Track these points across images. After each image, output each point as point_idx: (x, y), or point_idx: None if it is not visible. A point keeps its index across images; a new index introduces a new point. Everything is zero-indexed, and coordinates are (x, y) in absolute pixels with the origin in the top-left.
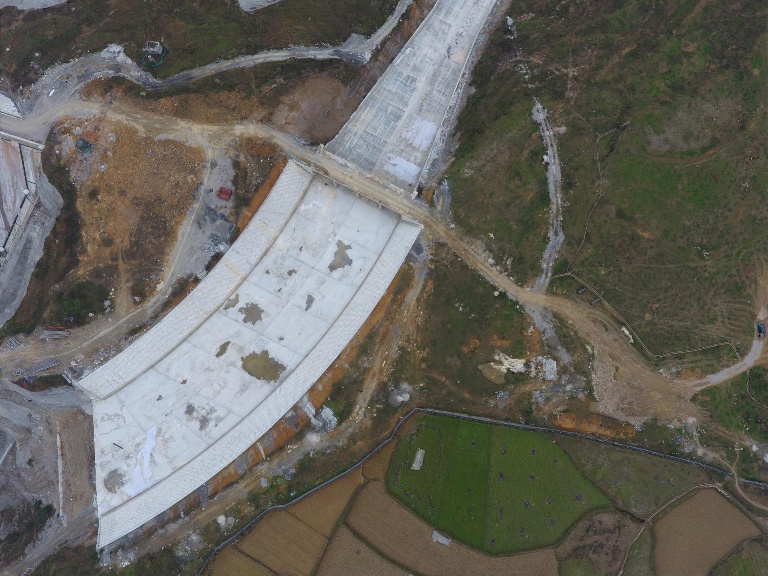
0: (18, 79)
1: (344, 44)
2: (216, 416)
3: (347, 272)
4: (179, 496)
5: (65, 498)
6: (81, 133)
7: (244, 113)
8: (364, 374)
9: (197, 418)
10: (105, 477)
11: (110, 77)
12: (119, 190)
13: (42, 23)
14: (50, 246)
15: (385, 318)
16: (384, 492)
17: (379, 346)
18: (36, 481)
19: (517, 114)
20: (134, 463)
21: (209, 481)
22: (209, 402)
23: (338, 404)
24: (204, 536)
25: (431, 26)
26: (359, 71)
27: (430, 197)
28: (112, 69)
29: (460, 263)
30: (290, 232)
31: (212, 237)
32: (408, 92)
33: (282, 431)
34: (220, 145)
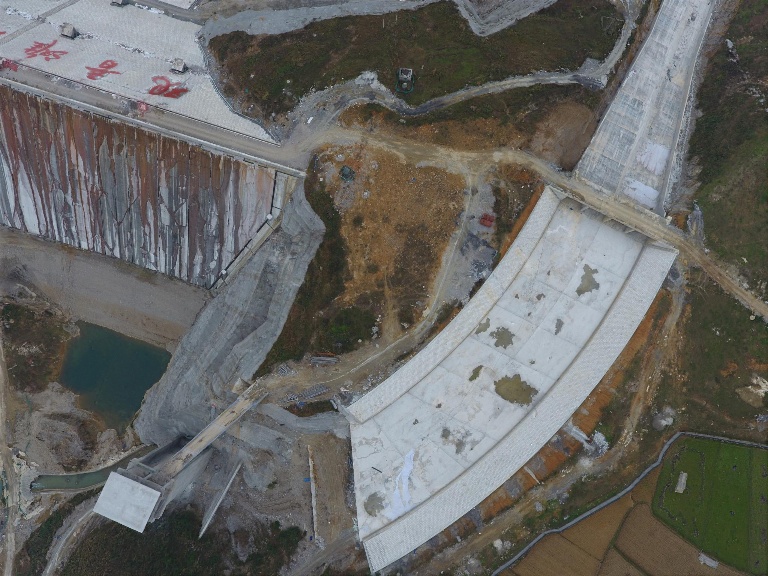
0: (270, 106)
1: (581, 69)
2: (471, 440)
3: (595, 296)
4: (449, 520)
5: (319, 521)
6: (343, 160)
7: (502, 140)
8: (631, 399)
9: (453, 442)
10: (365, 501)
11: (365, 104)
12: (383, 217)
13: (285, 49)
14: (314, 273)
15: (648, 343)
16: (650, 515)
17: (644, 371)
18: (272, 503)
19: (762, 139)
20: (393, 487)
21: (479, 505)
22: (464, 426)
23: (609, 429)
24: (482, 560)
25: (649, 49)
26: (599, 96)
27: (682, 222)
28: (367, 96)
29: (715, 288)
30: (538, 257)
31: (475, 263)
32: (637, 115)
33: (551, 455)
34: (480, 172)
